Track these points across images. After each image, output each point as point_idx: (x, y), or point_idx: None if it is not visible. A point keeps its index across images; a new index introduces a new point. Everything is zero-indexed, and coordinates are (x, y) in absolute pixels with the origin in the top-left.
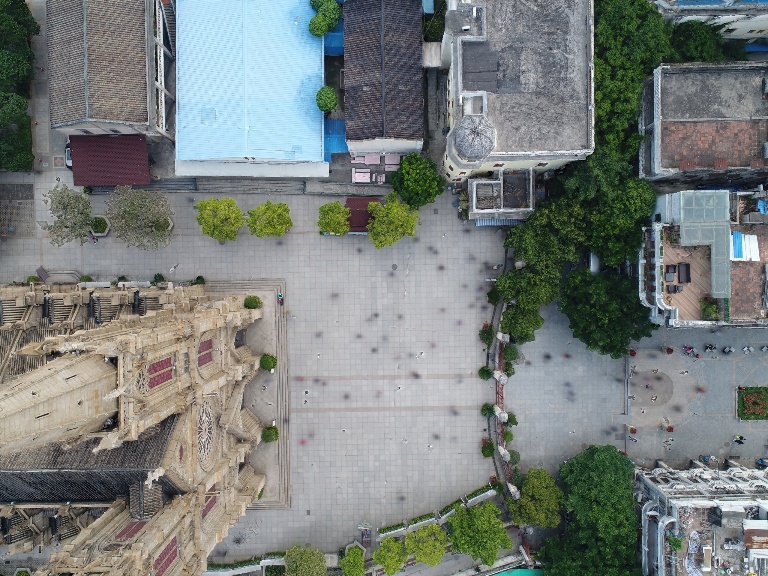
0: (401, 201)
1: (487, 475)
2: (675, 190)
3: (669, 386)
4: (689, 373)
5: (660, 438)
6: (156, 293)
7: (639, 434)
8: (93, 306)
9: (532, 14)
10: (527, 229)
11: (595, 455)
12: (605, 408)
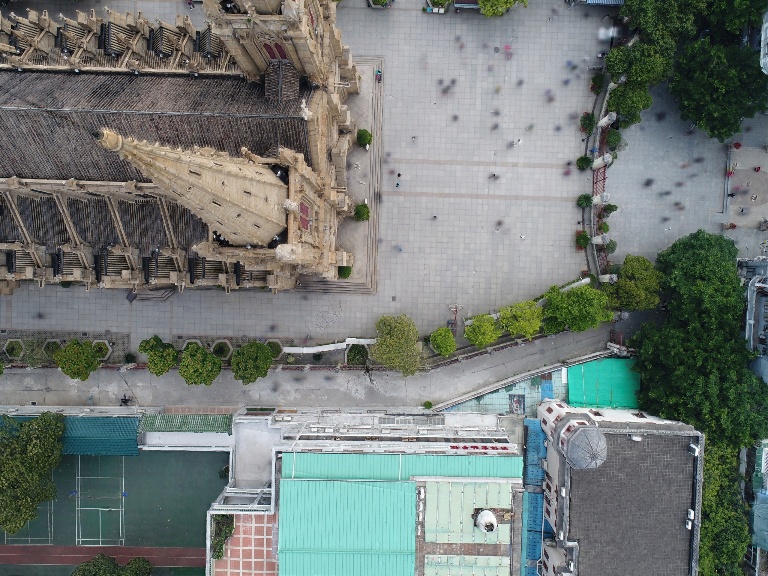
0: None
1: (578, 269)
2: None
3: None
4: None
5: (757, 239)
6: None
7: (736, 234)
8: (199, 44)
9: None
10: None
11: (700, 234)
12: (703, 206)
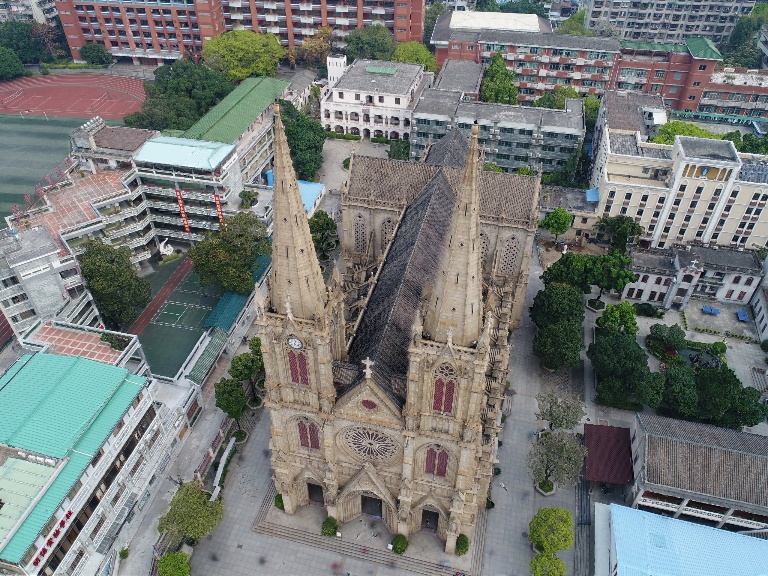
0: None
1: None
2: None
3: None
4: None
5: None
6: None
7: None
8: None
9: None
10: None
11: None
12: None
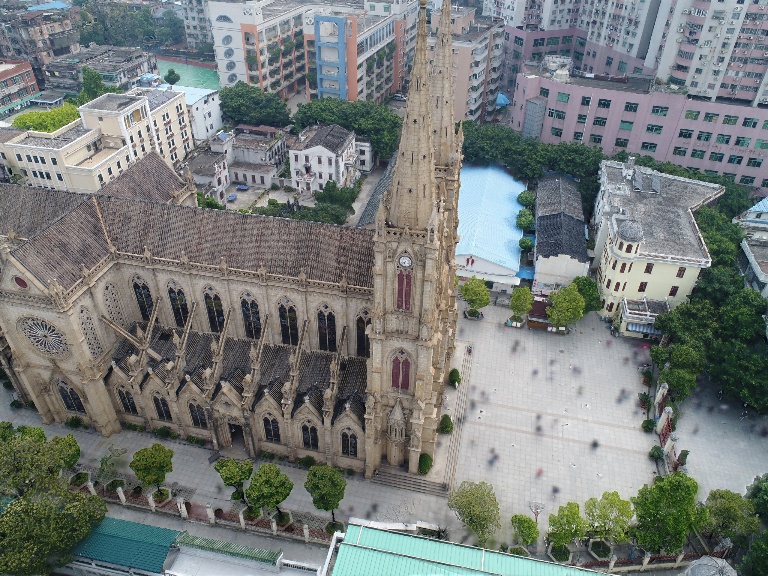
0: None
1: None
2: None
3: None
4: None
5: None
6: None
7: None
8: None
9: None
10: None
11: None
12: None
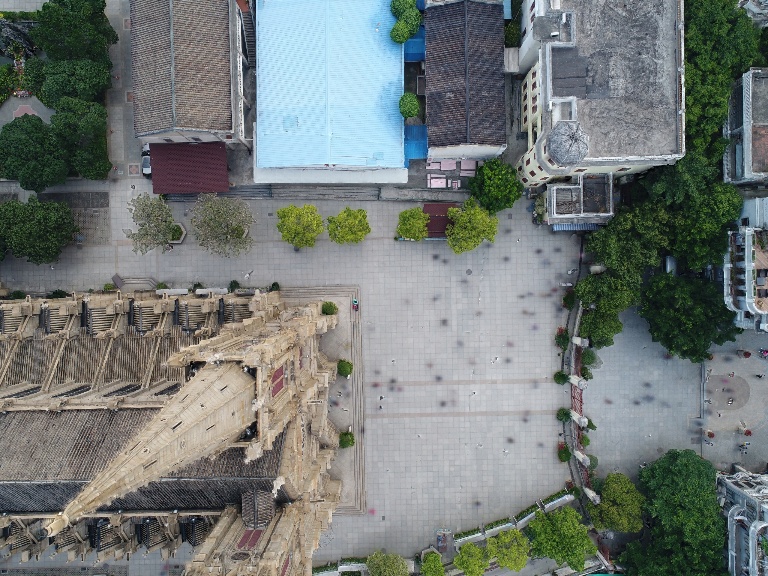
0: (479, 206)
1: (562, 480)
2: (762, 194)
3: (745, 390)
4: (765, 376)
5: (736, 442)
6: (242, 300)
7: (715, 438)
8: (178, 314)
9: (621, 19)
10: (609, 234)
11: (678, 459)
12: (681, 412)
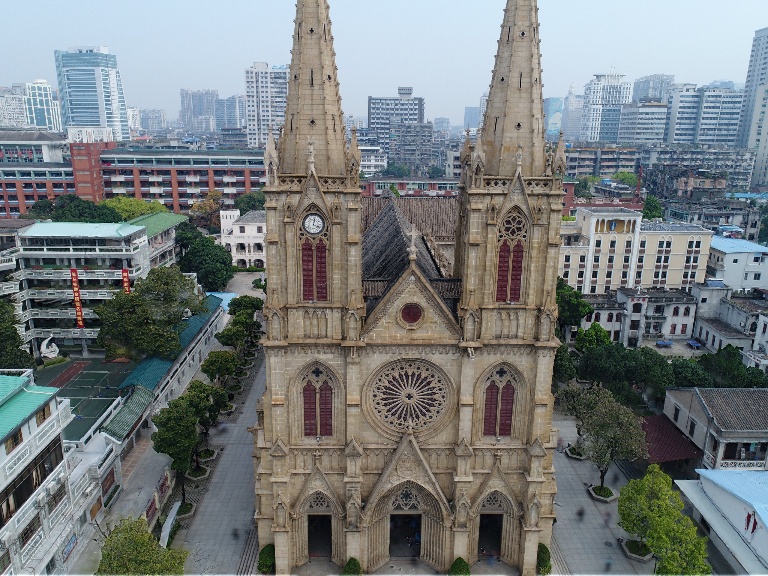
0: None
1: None
2: None
3: None
4: None
5: None
6: None
7: None
8: None
9: None
10: None
11: None
12: None
